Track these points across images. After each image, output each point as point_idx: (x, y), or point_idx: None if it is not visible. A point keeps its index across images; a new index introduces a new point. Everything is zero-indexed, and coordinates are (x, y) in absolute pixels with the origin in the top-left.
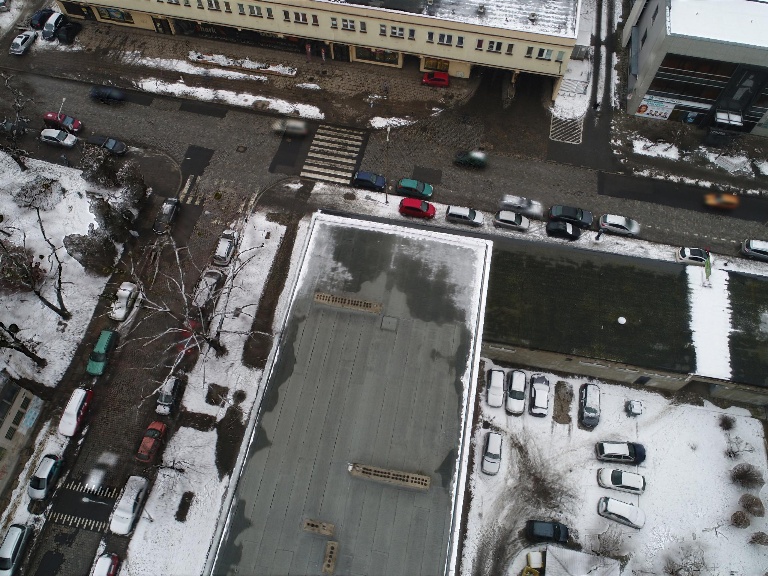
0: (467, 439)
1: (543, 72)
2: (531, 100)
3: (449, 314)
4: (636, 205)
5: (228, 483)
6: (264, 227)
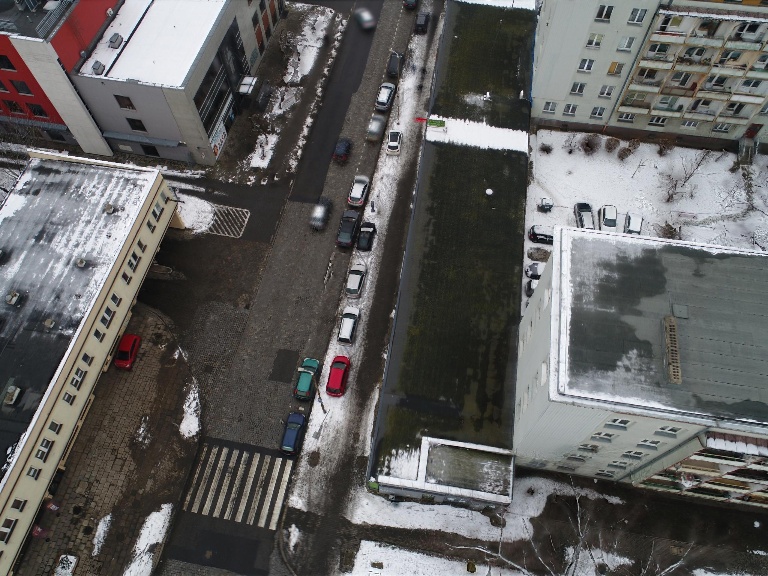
0: (765, 253)
1: (168, 222)
2: (178, 250)
3: (652, 262)
4: (333, 176)
5: (701, 570)
6: (364, 573)
